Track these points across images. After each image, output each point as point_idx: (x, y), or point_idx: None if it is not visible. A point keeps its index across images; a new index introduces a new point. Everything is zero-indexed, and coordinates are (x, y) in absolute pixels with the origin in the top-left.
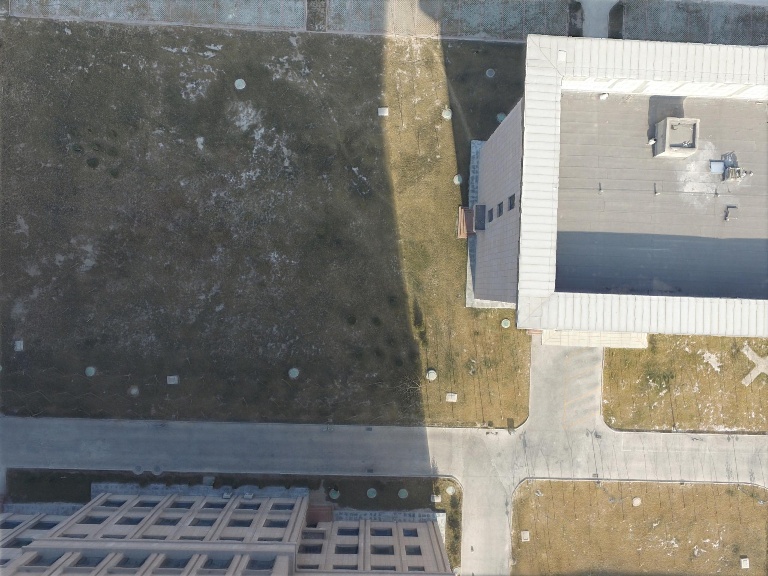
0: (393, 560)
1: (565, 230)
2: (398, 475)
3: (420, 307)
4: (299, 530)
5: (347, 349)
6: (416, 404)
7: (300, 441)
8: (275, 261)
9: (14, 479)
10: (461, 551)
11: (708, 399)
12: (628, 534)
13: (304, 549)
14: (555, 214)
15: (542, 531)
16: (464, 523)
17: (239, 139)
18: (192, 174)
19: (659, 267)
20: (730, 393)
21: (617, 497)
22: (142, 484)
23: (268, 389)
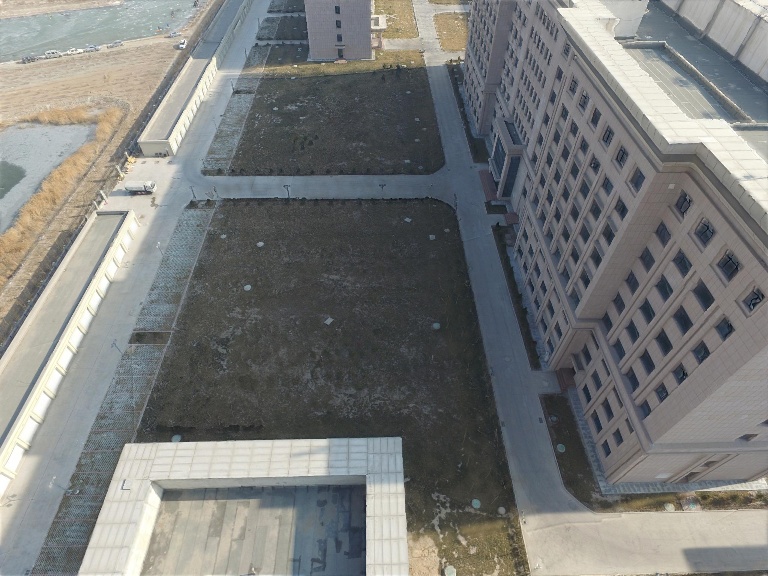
0: None
1: None
2: (447, 71)
3: None
4: None
5: None
6: None
7: (439, 91)
8: None
9: (479, 160)
10: None
11: None
12: None
13: None
14: None
15: None
16: None
17: None
18: (317, 119)
19: None
20: None
21: None
22: (468, 122)
23: None
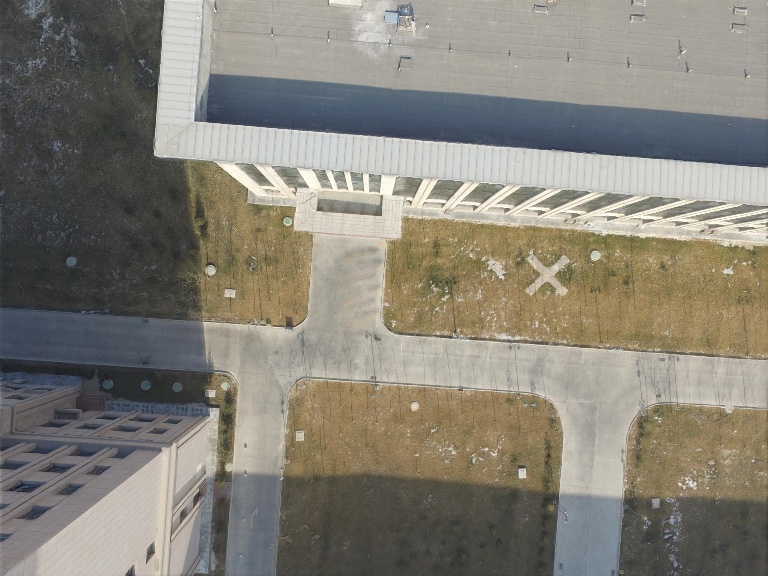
0: (127, 435)
1: (236, 74)
2: (173, 368)
3: (202, 202)
4: (40, 403)
5: (127, 240)
6: (194, 298)
7: (76, 330)
8: (58, 150)
9: None
10: (234, 447)
11: (491, 307)
12: (406, 439)
13: (50, 425)
14: (197, 43)
15: (317, 431)
16: (238, 420)
17: (27, 27)
18: None
19: (332, 116)
20: (514, 302)
21: (395, 401)
22: None
23: (45, 276)
